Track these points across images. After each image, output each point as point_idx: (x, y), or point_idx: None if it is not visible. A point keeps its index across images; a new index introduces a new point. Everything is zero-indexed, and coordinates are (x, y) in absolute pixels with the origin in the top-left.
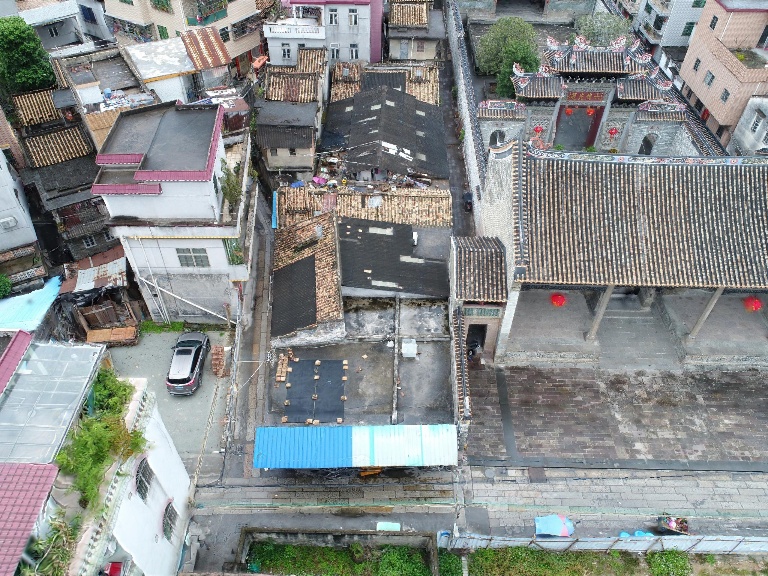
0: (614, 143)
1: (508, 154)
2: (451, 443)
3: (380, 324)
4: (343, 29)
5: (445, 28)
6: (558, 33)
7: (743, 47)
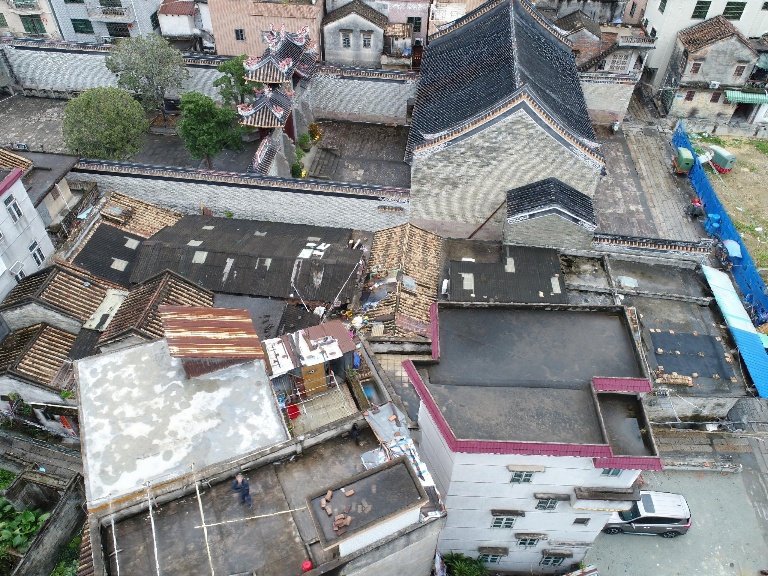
0: None
1: (506, 116)
2: (715, 272)
3: (596, 302)
4: (11, 236)
5: None
6: (16, 108)
7: (256, 1)
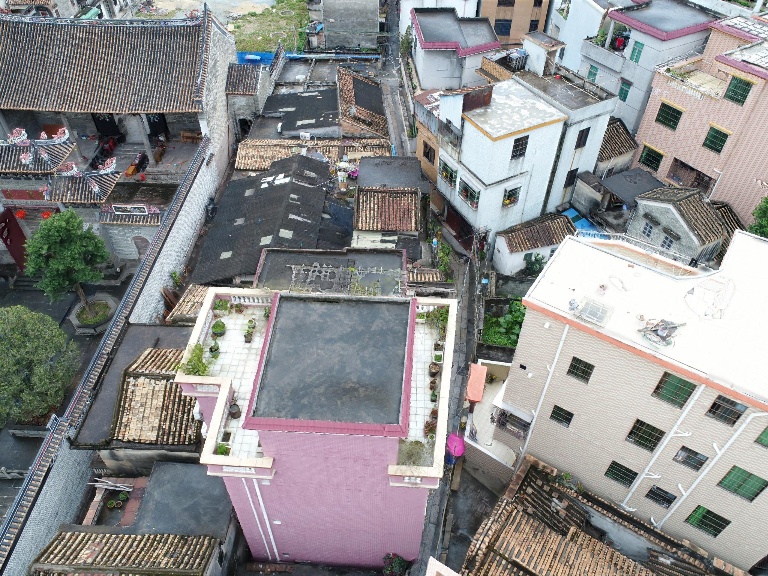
0: (1, 242)
1: None
2: None
3: None
4: None
5: (114, 354)
6: None
7: None
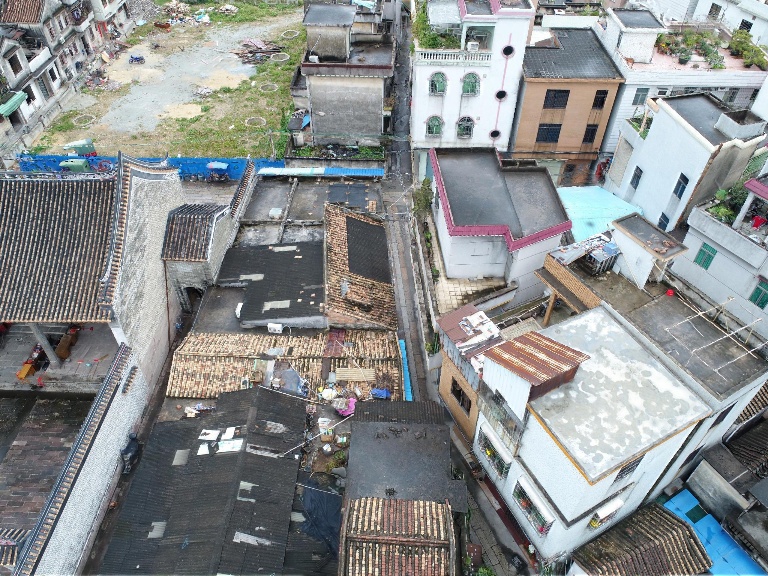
0: None
1: None
2: None
3: (295, 235)
4: None
5: None
6: None
7: None
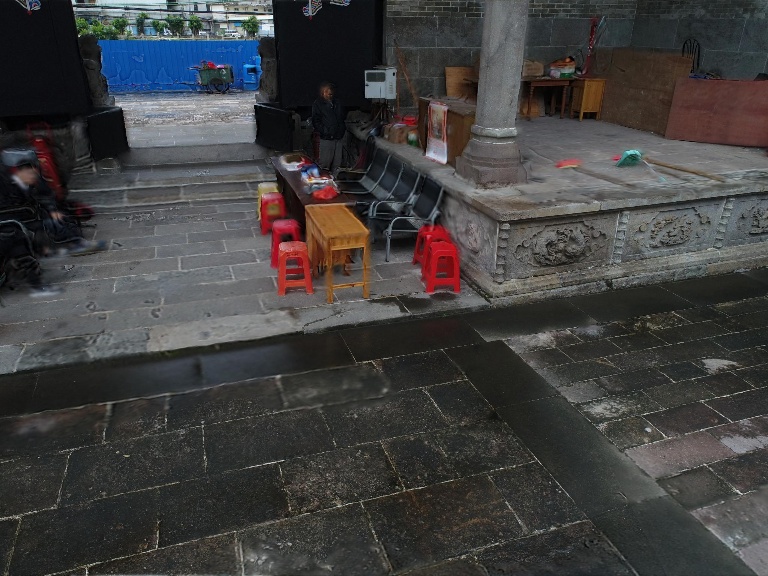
0: None
1: None
2: None
3: None
4: None
5: None
6: None
7: None
